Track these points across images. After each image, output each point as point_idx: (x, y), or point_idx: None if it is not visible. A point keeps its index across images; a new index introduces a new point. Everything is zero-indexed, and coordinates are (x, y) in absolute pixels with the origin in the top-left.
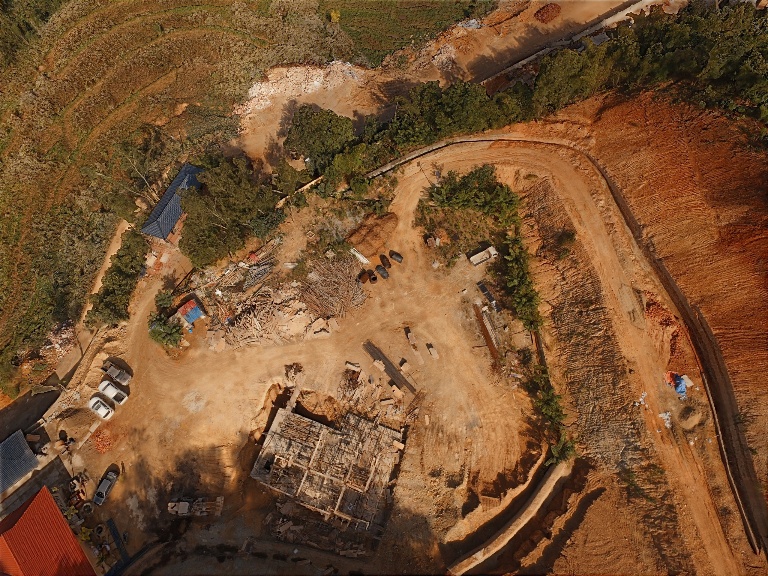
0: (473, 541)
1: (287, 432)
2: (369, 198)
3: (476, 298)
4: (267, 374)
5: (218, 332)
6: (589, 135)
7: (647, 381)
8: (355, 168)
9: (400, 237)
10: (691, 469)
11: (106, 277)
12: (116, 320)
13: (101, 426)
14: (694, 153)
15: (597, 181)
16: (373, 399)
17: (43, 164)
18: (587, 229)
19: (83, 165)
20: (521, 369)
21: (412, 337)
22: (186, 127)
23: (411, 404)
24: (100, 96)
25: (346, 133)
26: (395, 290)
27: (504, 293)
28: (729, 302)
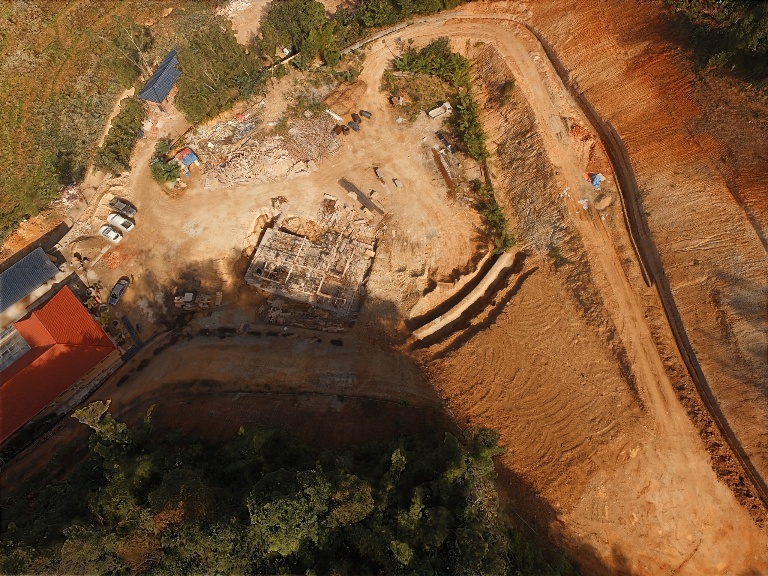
0: (433, 316)
1: (275, 245)
2: (341, 71)
3: (434, 144)
4: (256, 205)
5: (212, 173)
6: (527, 9)
7: (570, 179)
8: (328, 45)
9: (369, 100)
10: (602, 236)
11: (109, 133)
12: (120, 166)
13: (111, 249)
14: (609, 9)
15: (533, 43)
16: (348, 220)
17: (40, 59)
18: (524, 77)
19: (78, 60)
20: (472, 194)
21: (380, 172)
22: (173, 26)
23: (380, 223)
24: (91, 2)
25: (319, 16)
26: (365, 140)
27: (458, 139)
28: (633, 113)
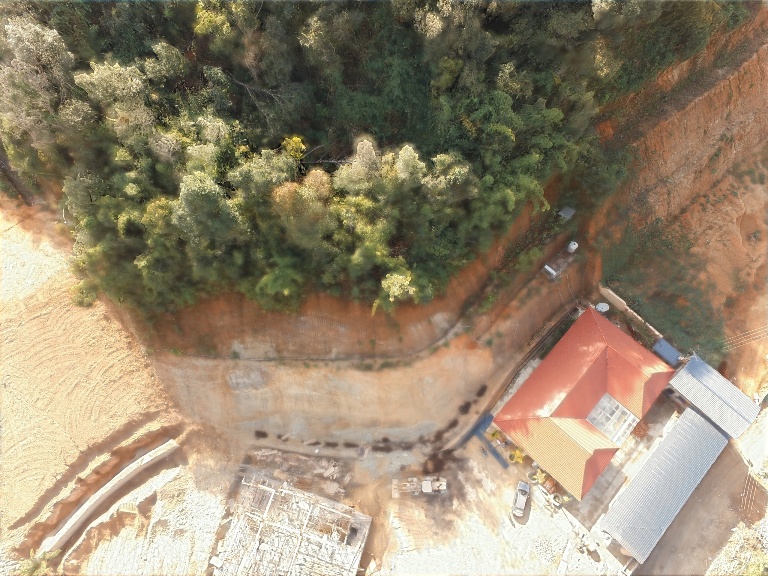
0: (155, 469)
1: (335, 573)
2: None
3: None
4: None
5: None
6: None
7: None
8: None
9: None
10: None
11: None
12: None
13: (555, 569)
14: None
15: None
16: None
17: None
18: None
19: None
20: None
21: None
22: None
23: None
24: None
25: None
26: None
27: None
28: None
